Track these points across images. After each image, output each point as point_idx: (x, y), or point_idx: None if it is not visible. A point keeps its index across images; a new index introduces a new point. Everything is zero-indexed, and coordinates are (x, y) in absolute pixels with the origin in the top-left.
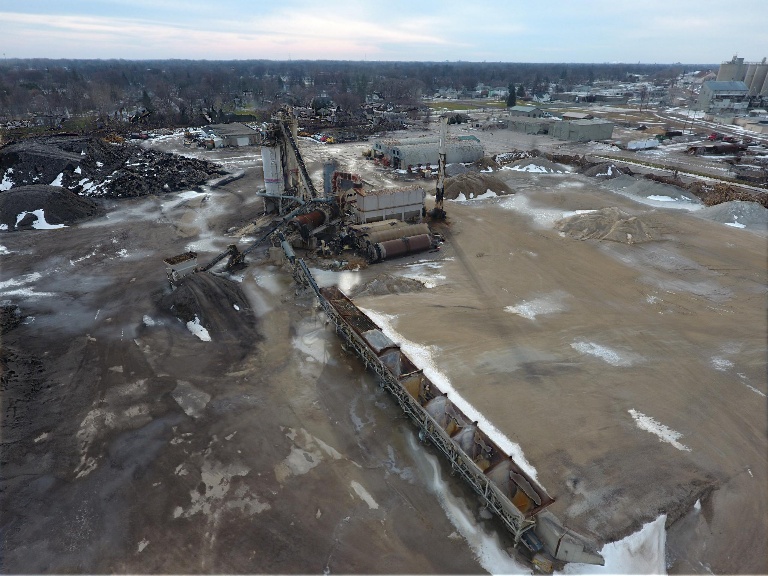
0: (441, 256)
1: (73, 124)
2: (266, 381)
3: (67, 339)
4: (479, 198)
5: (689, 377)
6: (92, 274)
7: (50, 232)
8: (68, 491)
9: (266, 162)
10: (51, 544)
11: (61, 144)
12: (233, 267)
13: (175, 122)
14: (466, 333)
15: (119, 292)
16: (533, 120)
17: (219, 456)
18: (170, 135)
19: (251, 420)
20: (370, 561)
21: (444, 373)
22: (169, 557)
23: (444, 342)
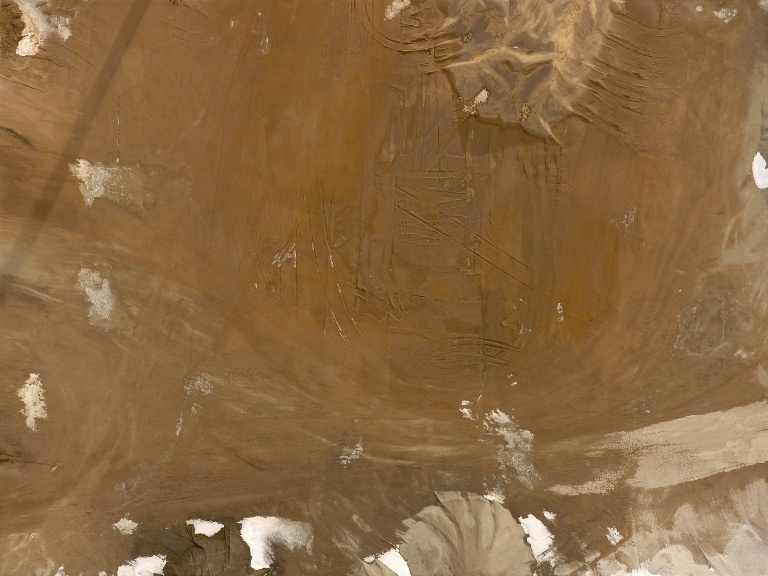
0: None
1: None
2: None
3: None
4: None
5: (139, 379)
6: None
7: None
8: None
9: None
10: None
11: None
12: None
13: None
14: None
15: None
16: None
17: None
18: None
19: None
20: None
21: None
22: None
23: None
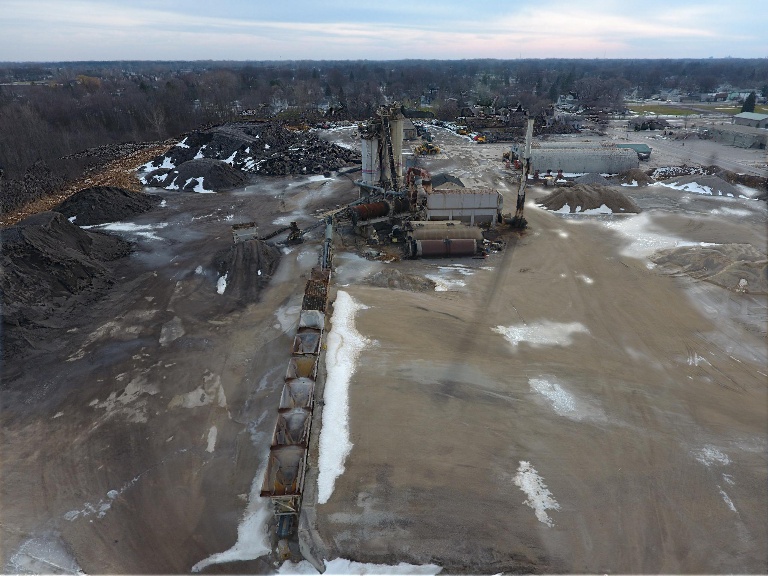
0: (481, 264)
1: (286, 114)
2: (229, 334)
3: (142, 271)
4: (587, 213)
5: (643, 455)
6: (197, 229)
7: (200, 195)
8: (55, 367)
9: (363, 153)
10: (21, 395)
11: (246, 128)
12: (291, 241)
13: (362, 115)
14: (421, 338)
15: (200, 245)
16: (750, 130)
17: (150, 376)
18: (348, 127)
19: (192, 358)
20: (168, 485)
21: (357, 366)
22: (64, 428)
23: (389, 340)
